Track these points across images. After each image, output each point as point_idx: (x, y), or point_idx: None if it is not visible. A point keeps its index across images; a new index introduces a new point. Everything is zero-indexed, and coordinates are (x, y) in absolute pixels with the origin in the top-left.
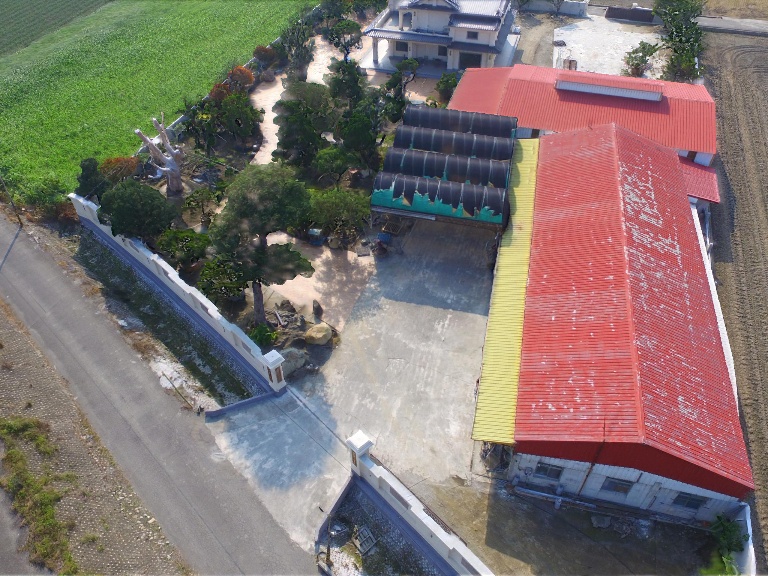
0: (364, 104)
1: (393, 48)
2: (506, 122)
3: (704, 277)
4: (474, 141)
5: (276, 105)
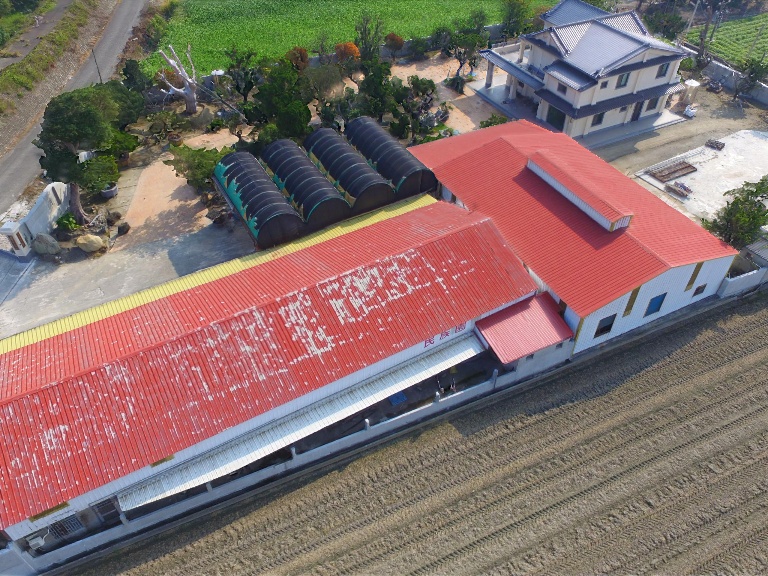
0: (331, 100)
1: None
2: (406, 167)
3: (303, 389)
4: (349, 167)
5: None
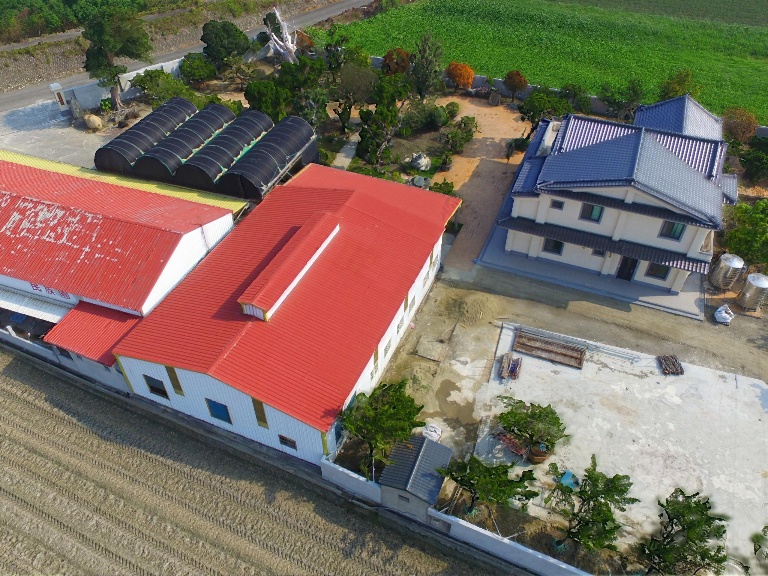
0: None
1: None
2: (236, 167)
3: None
4: (208, 145)
5: None
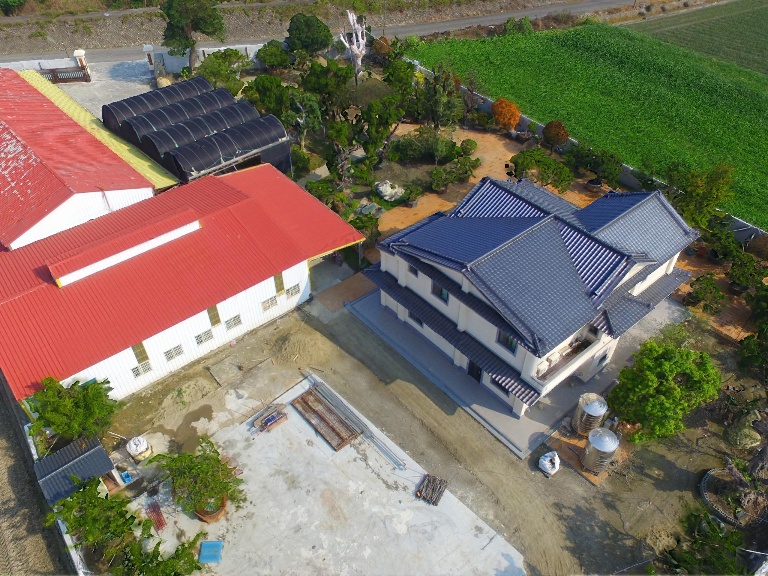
0: None
1: None
2: (178, 148)
3: None
4: None
5: None
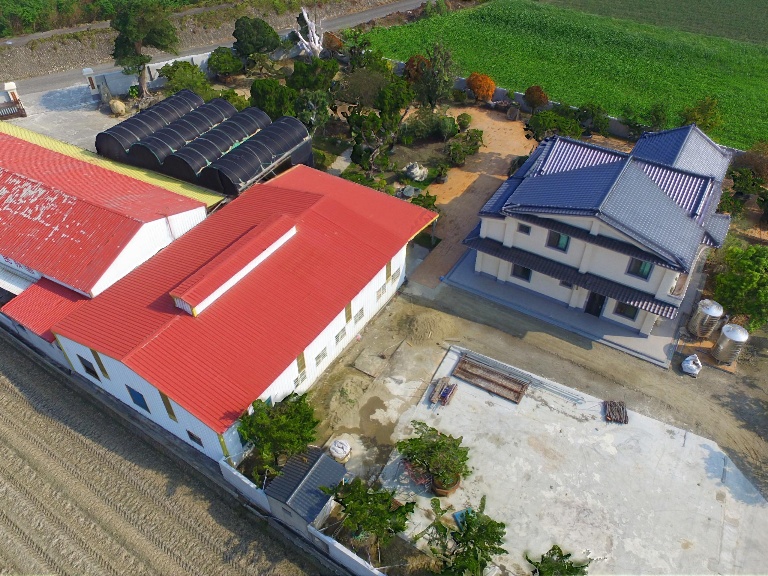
0: None
1: None
2: (217, 161)
3: None
4: (199, 138)
5: None
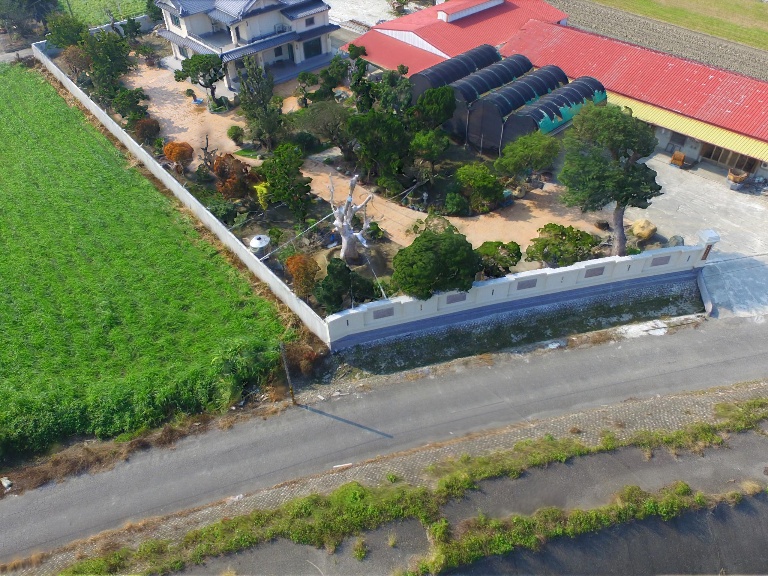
0: (401, 87)
1: (234, 69)
2: (488, 49)
3: None
4: (505, 67)
5: (350, 125)
